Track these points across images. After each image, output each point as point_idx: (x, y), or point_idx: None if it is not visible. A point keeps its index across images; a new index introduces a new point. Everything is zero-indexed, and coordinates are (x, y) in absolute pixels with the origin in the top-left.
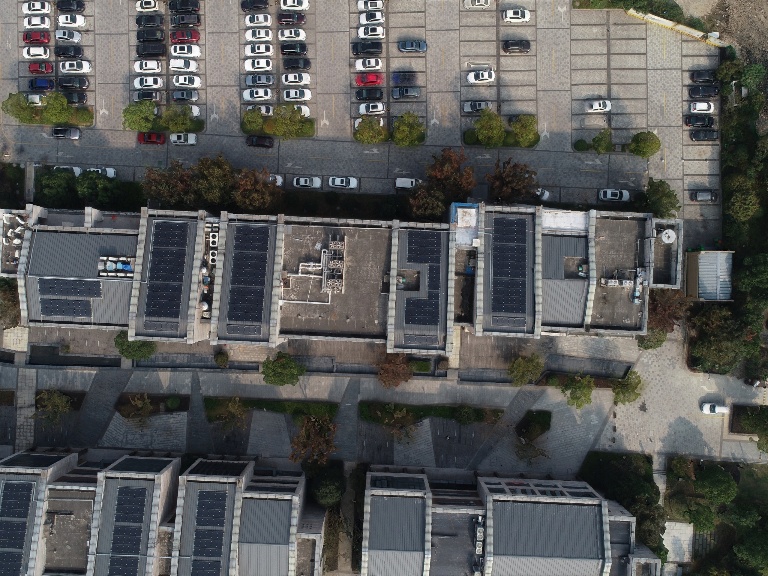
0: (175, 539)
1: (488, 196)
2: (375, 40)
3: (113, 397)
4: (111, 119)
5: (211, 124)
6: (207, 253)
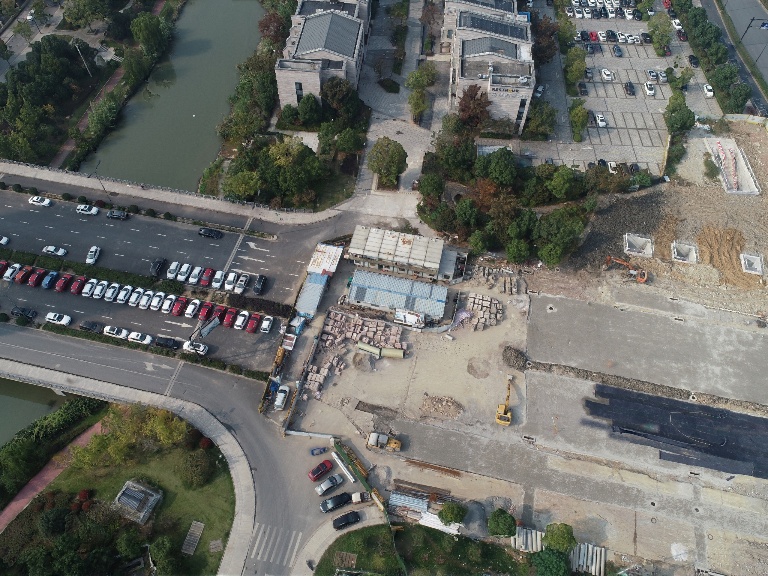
0: None
1: None
2: (617, 40)
3: None
4: None
5: None
6: None
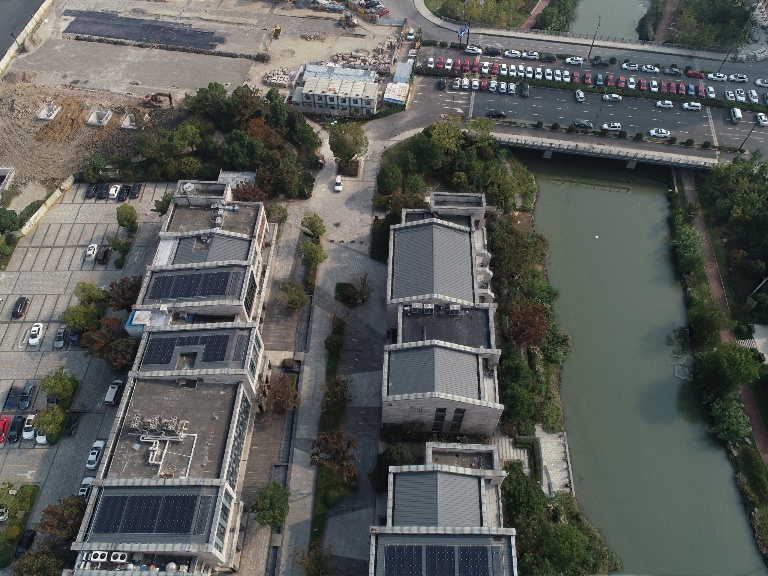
0: None
1: None
2: None
3: None
4: None
5: None
6: (114, 569)
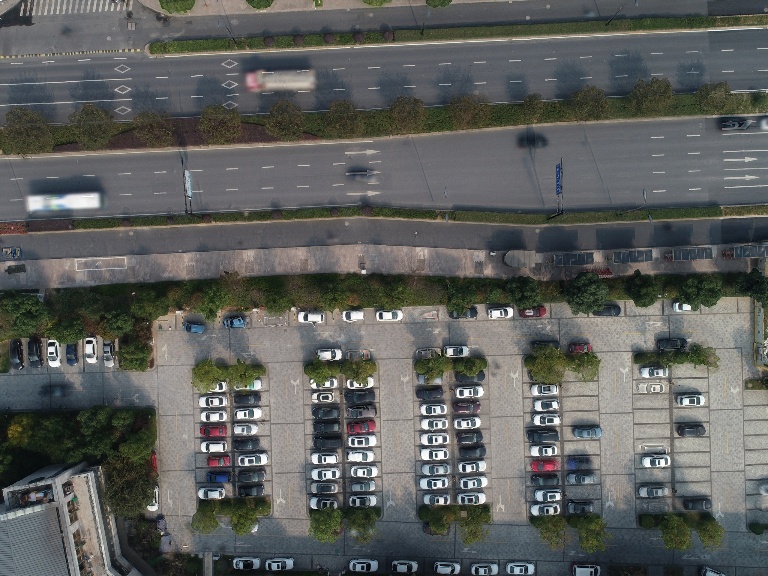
0: None
1: None
2: (549, 425)
3: None
4: (288, 508)
5: (387, 511)
6: None
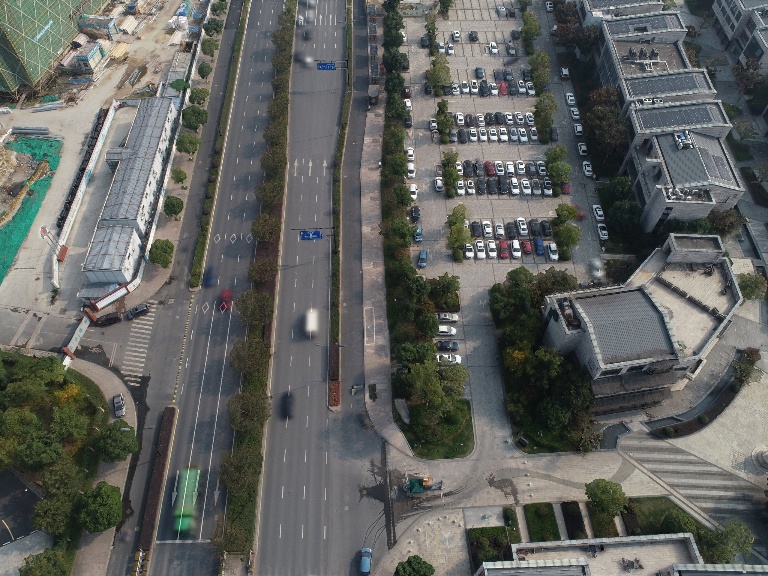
0: None
1: (562, 47)
2: None
3: (761, 209)
4: None
5: None
6: None
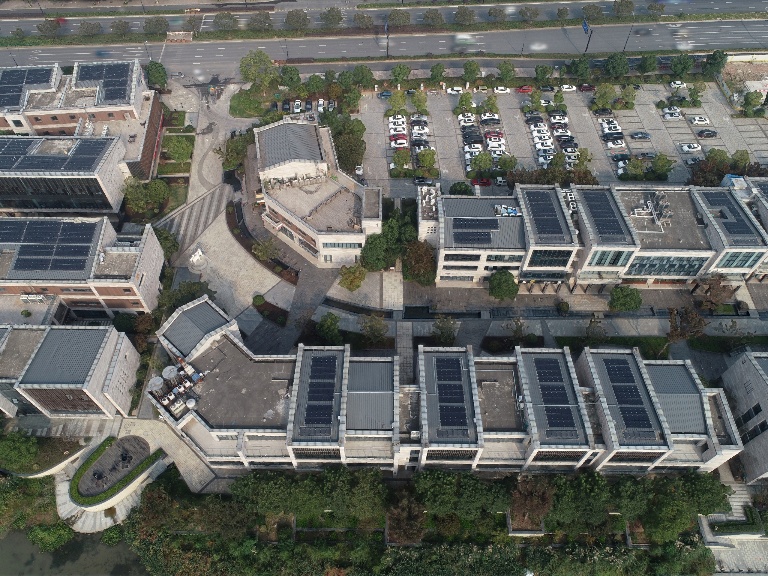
0: (599, 390)
1: None
2: None
3: (478, 340)
4: (451, 175)
5: None
6: None
